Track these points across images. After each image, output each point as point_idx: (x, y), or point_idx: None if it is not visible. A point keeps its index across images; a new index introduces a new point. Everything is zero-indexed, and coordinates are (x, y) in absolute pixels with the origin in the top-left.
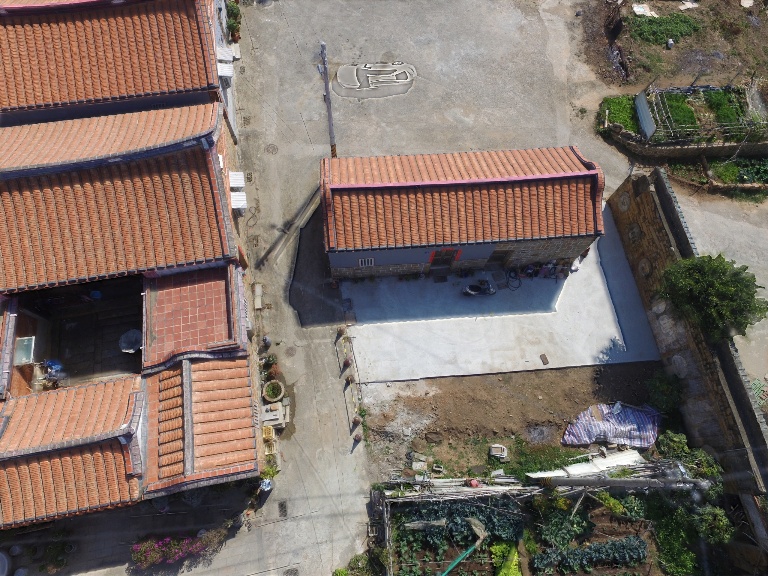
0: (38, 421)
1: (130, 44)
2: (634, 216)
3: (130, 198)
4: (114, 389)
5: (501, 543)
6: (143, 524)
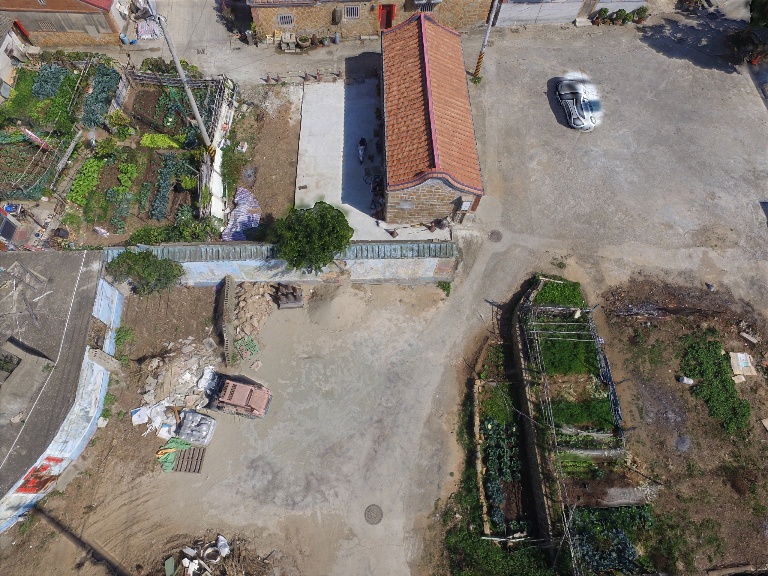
0: None
1: None
2: None
3: None
4: None
5: None
6: None
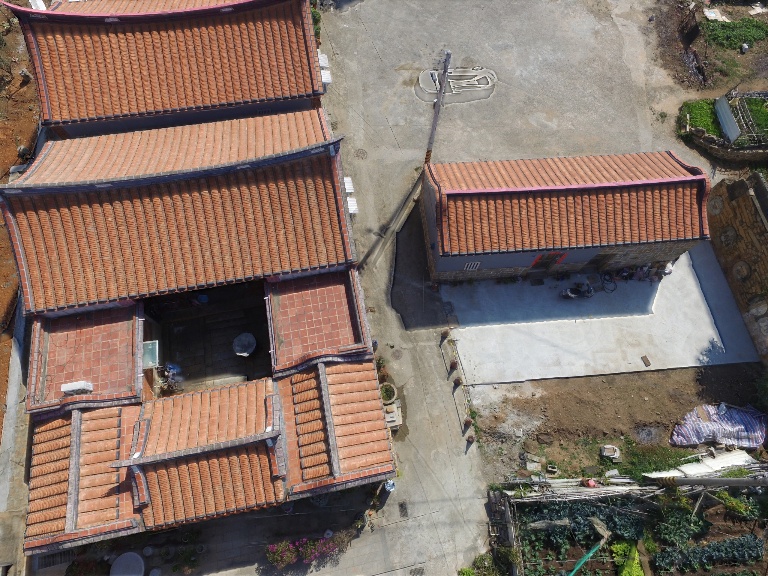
0: (179, 424)
1: (237, 51)
2: (728, 219)
3: (256, 204)
4: (248, 392)
5: (621, 542)
6: (268, 525)
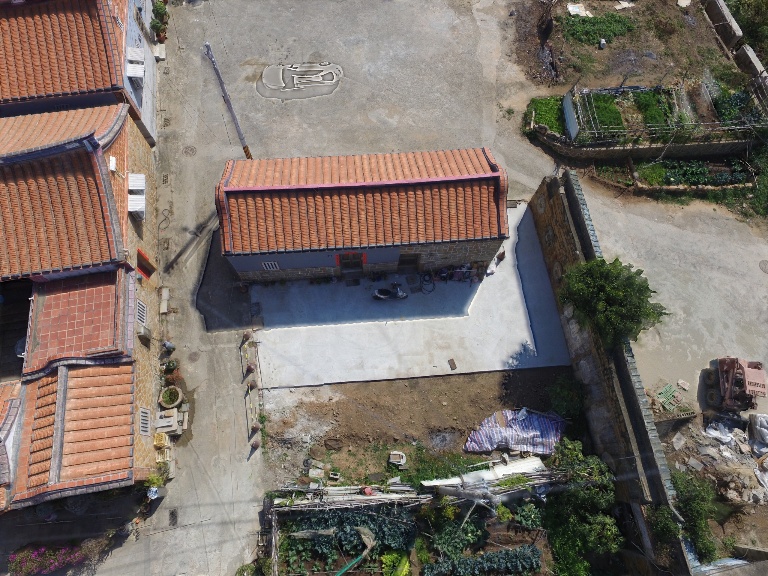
0: None
1: (31, 44)
2: (549, 219)
3: (14, 201)
4: None
5: (392, 552)
6: (29, 533)
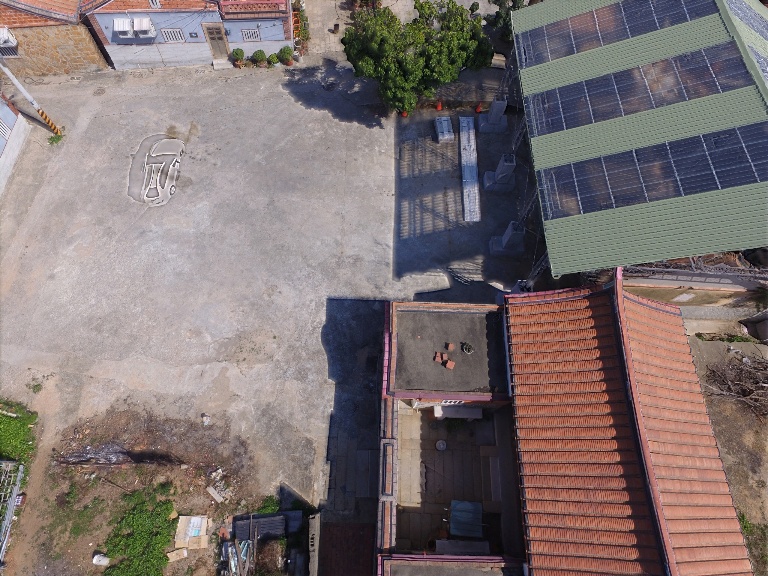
0: None
1: None
2: None
3: None
4: None
5: None
6: None
